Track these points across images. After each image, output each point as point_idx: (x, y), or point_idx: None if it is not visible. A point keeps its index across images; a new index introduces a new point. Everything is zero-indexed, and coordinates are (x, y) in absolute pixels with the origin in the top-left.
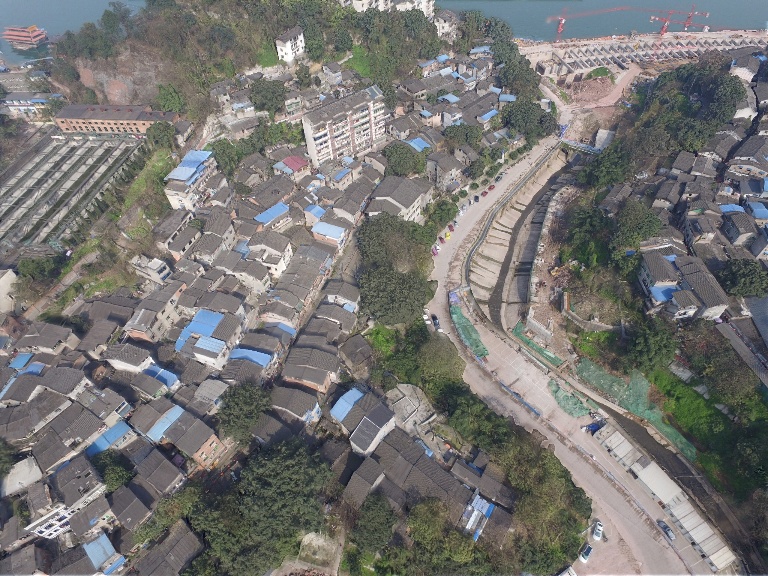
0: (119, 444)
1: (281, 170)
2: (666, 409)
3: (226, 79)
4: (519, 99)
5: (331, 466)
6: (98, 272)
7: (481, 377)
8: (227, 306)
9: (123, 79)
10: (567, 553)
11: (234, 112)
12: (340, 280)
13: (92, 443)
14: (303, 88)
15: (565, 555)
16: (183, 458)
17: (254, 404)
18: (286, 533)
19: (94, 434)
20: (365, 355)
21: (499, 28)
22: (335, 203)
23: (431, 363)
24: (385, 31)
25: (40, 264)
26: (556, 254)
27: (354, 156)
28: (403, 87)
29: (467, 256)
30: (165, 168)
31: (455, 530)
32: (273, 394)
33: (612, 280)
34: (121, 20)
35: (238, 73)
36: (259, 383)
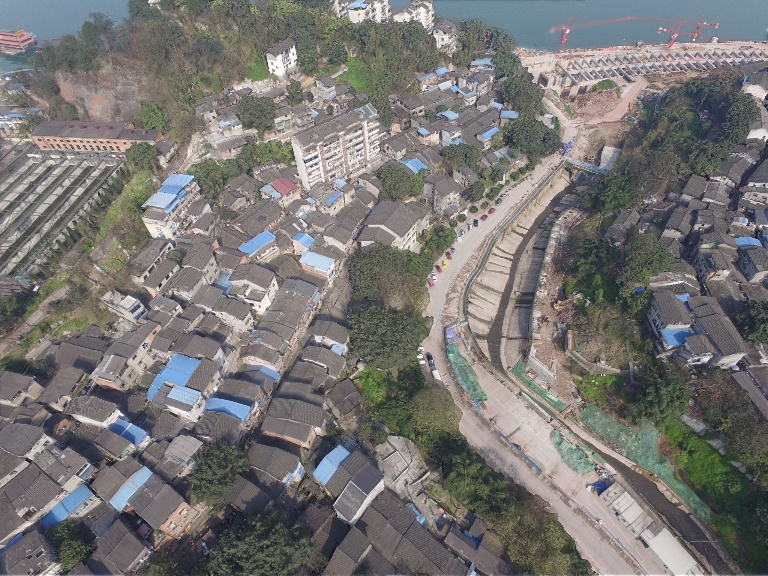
0: (79, 511)
1: (269, 194)
2: (678, 463)
3: (213, 94)
4: (521, 115)
5: (313, 535)
6: (67, 310)
7: (479, 426)
8: (204, 351)
9: (105, 94)
10: None
11: (221, 130)
12: (329, 315)
13: (49, 511)
14: (294, 104)
15: None
16: (149, 528)
17: (229, 466)
18: None
19: (51, 502)
20: (354, 403)
21: (501, 39)
22: (325, 230)
23: (424, 413)
24: (381, 43)
25: (1, 304)
26: (559, 285)
27: (347, 177)
28: (400, 103)
29: (465, 286)
30: (144, 193)
31: None
32: (251, 452)
33: (619, 318)
34: (102, 32)
35: (226, 88)
36: (237, 437)
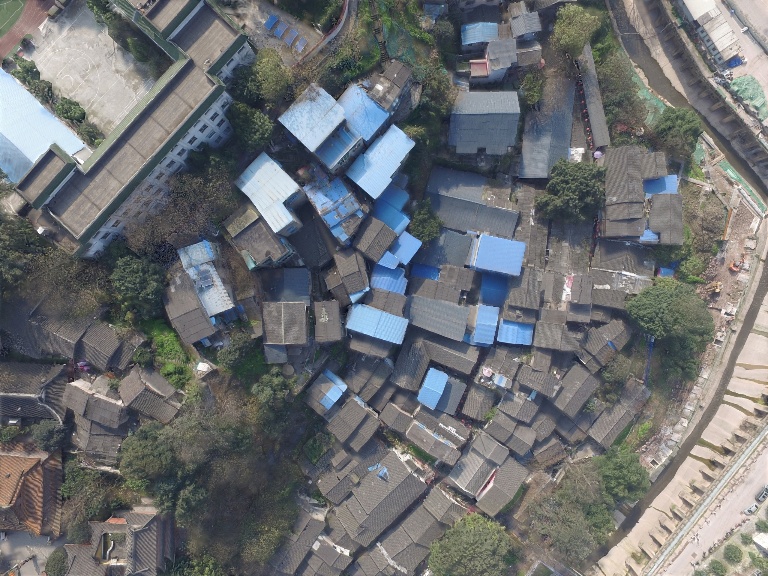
0: None
1: None
2: None
3: None
4: None
5: None
6: None
7: None
8: None
9: None
10: None
11: None
12: None
13: None
14: None
15: None
16: None
17: None
18: None
19: None
20: None
21: None
22: None
23: None
24: None
25: None
26: None
27: None
28: None
29: None
30: None
31: None
32: None
33: None
34: None
35: None
36: None
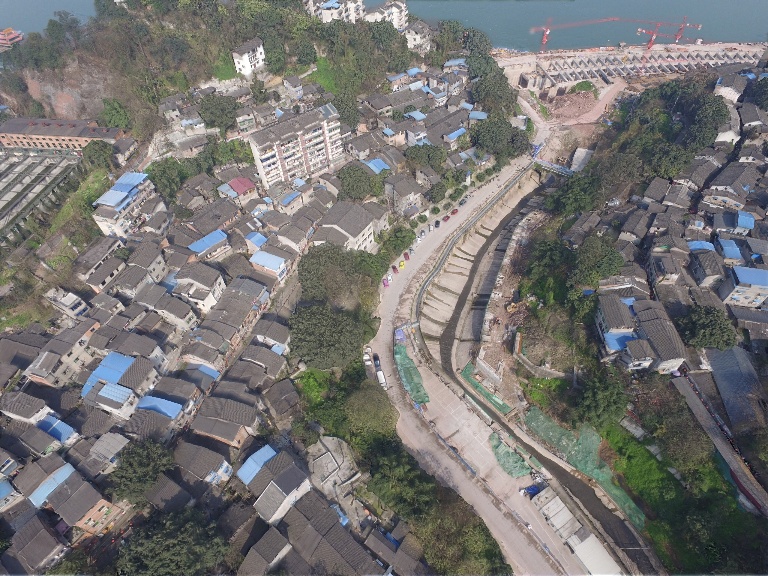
0: (0, 507)
1: (225, 193)
2: (617, 468)
3: (179, 93)
4: (491, 116)
5: (233, 535)
6: (10, 306)
7: (418, 428)
8: (139, 349)
9: (70, 92)
10: None
11: (183, 129)
12: (277, 315)
13: None
14: (259, 103)
15: None
16: (68, 525)
17: (151, 464)
18: None
19: None
20: (290, 403)
21: (477, 39)
22: (279, 230)
23: (359, 414)
24: (351, 43)
25: None
26: (515, 287)
27: (309, 177)
28: (367, 103)
29: (420, 288)
30: (98, 191)
31: None
32: (177, 451)
33: (569, 321)
34: (68, 30)
35: (192, 86)
36: (167, 435)
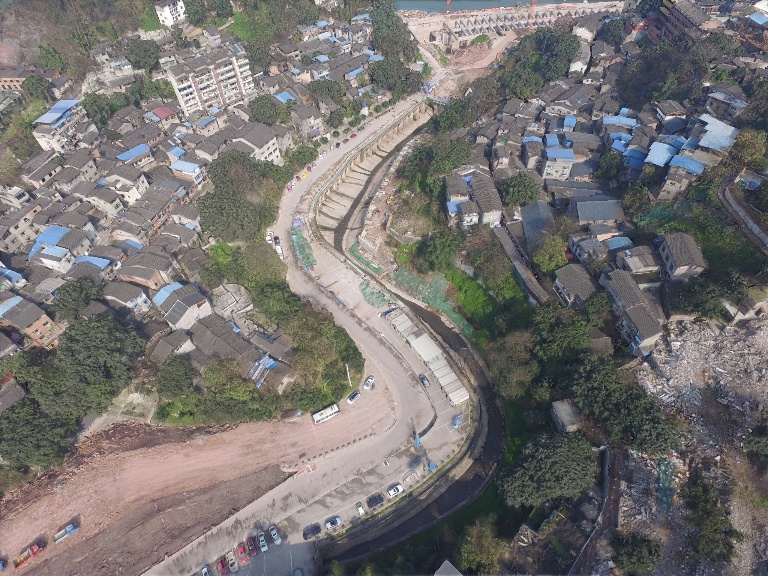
0: None
1: (150, 118)
2: (458, 301)
3: (108, 41)
4: (388, 59)
5: (151, 341)
6: None
7: (305, 281)
8: (74, 222)
9: (10, 42)
10: (333, 395)
11: (112, 70)
12: None
13: None
14: (180, 49)
15: (332, 396)
16: (20, 335)
17: (84, 292)
18: (96, 382)
19: None
20: (201, 263)
21: None
22: (196, 145)
23: None
24: None
25: None
26: (397, 187)
27: None
28: (279, 49)
29: (319, 191)
30: (37, 116)
31: (239, 378)
32: (105, 288)
33: (430, 203)
34: None
35: (120, 36)
36: (99, 283)
